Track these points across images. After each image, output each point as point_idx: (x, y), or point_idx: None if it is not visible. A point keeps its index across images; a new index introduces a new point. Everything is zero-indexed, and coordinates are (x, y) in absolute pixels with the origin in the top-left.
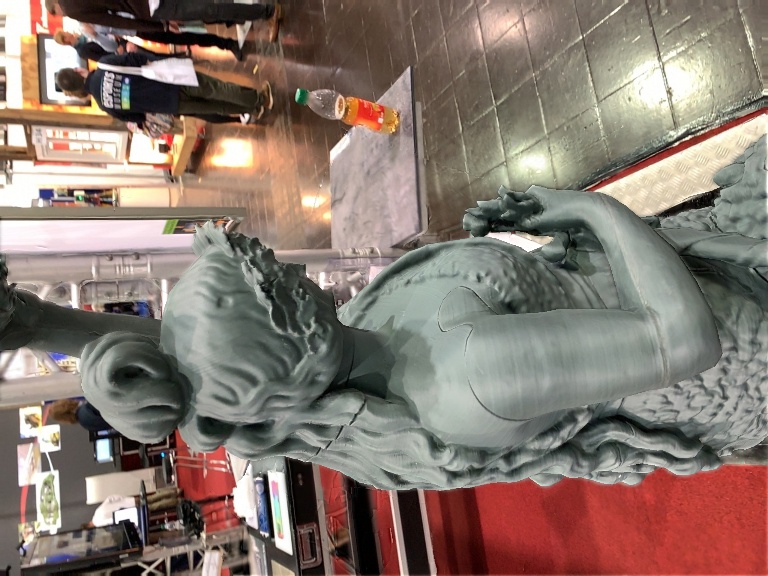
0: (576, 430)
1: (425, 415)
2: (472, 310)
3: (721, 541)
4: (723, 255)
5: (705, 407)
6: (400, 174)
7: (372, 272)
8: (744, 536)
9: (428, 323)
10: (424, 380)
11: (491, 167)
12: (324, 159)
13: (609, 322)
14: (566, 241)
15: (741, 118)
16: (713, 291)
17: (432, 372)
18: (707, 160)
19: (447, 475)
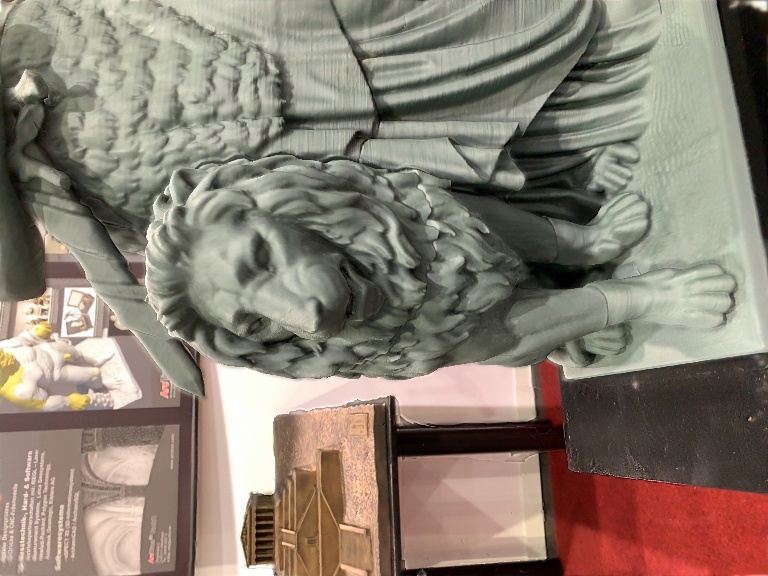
0: None
1: None
2: None
3: None
4: None
5: None
6: None
7: None
8: None
9: None
10: None
11: None
12: None
13: None
14: None
15: None
16: (113, 237)
17: None
18: None
19: None
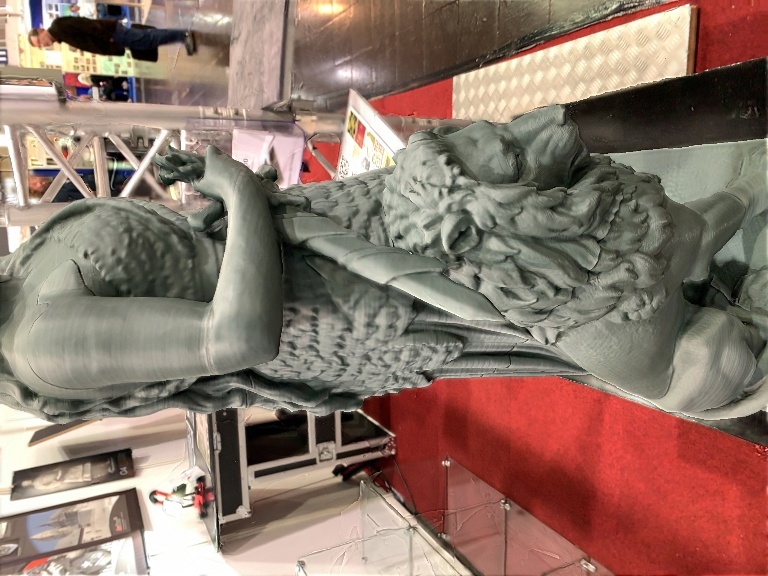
0: (186, 384)
1: (15, 372)
2: (65, 287)
3: (558, 405)
4: (328, 255)
5: (325, 371)
6: (273, 30)
7: (235, 135)
8: (575, 405)
9: (34, 291)
10: (11, 345)
11: (444, 3)
12: (191, 3)
13: (168, 319)
14: (214, 213)
15: (664, 5)
16: (339, 277)
17: (13, 342)
18: (627, 45)
19: (46, 416)
